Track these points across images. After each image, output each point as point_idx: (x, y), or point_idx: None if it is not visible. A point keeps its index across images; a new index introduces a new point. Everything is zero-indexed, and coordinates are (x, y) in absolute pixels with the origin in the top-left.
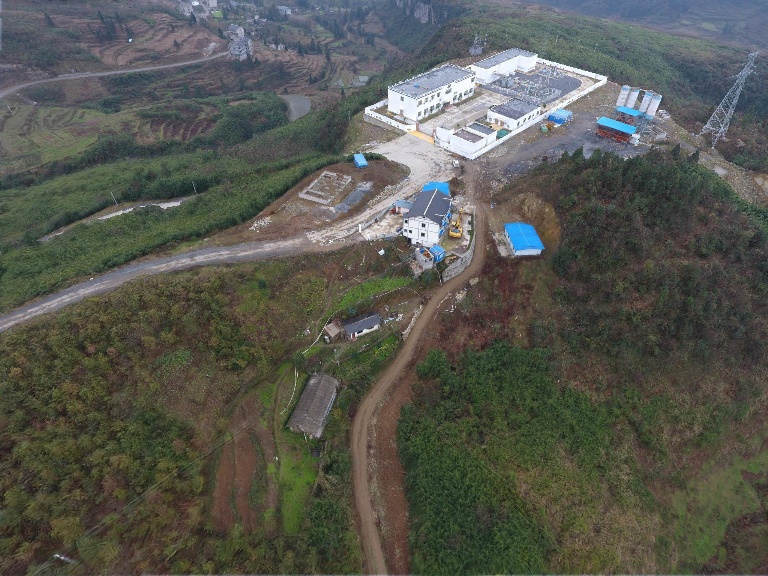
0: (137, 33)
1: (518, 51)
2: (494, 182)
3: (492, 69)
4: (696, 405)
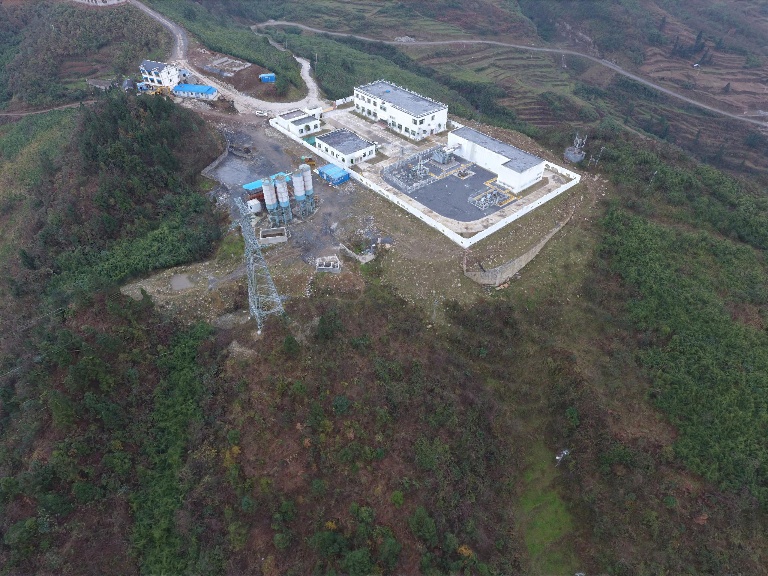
0: (716, 64)
1: (533, 162)
2: (224, 125)
3: (458, 139)
4: (20, 239)
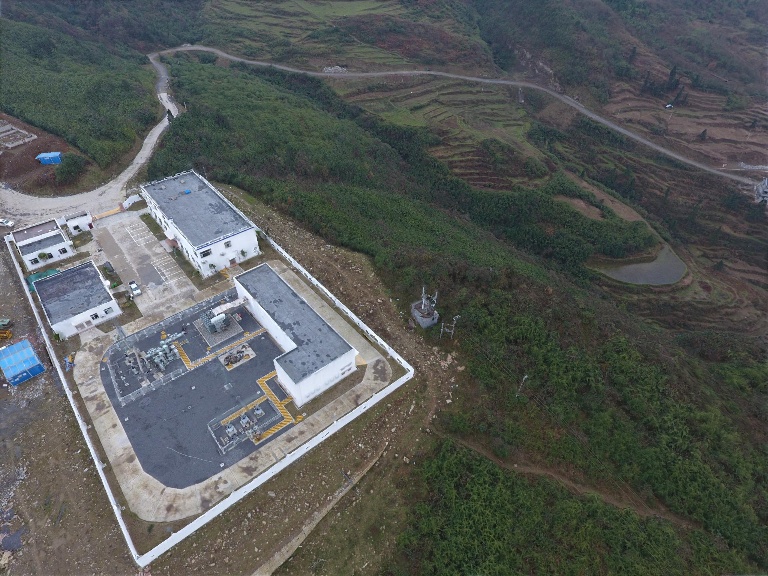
0: (692, 105)
1: (331, 352)
2: None
3: None
4: None
